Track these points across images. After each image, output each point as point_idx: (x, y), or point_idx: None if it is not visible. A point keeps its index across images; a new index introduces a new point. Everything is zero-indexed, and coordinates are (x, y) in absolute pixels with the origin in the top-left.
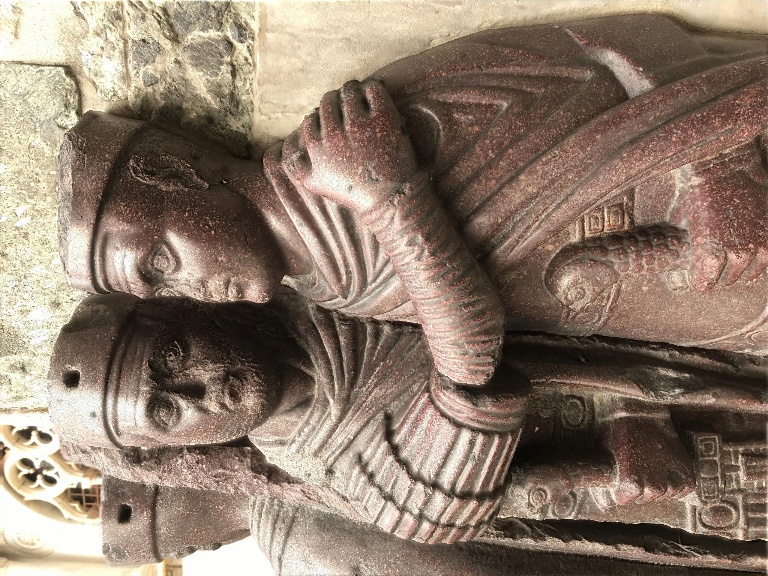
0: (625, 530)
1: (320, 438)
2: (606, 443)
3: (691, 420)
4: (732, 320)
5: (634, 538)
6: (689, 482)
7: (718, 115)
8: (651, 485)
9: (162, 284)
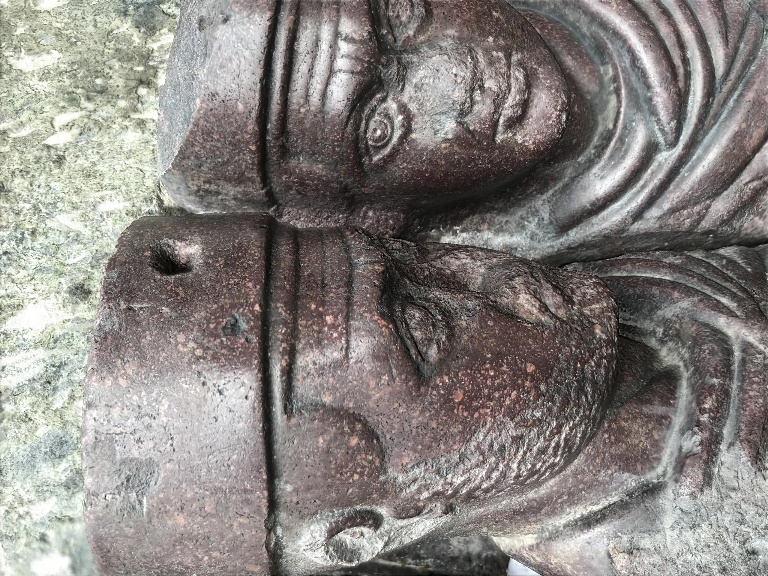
0: None
1: (756, 404)
2: None
3: None
4: None
5: None
6: None
7: None
8: None
9: (395, 57)
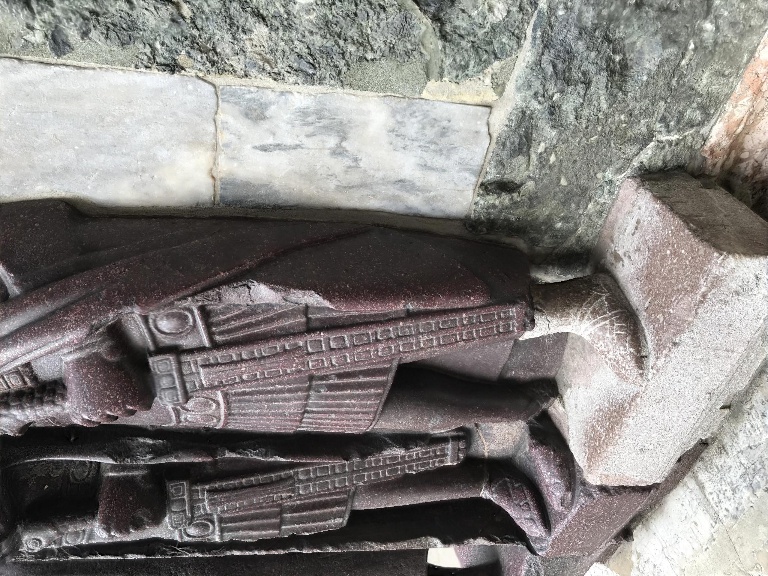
0: (137, 541)
1: None
2: (98, 495)
3: (174, 467)
4: (155, 422)
5: (141, 547)
6: (149, 523)
7: (49, 329)
8: (115, 530)
9: None
